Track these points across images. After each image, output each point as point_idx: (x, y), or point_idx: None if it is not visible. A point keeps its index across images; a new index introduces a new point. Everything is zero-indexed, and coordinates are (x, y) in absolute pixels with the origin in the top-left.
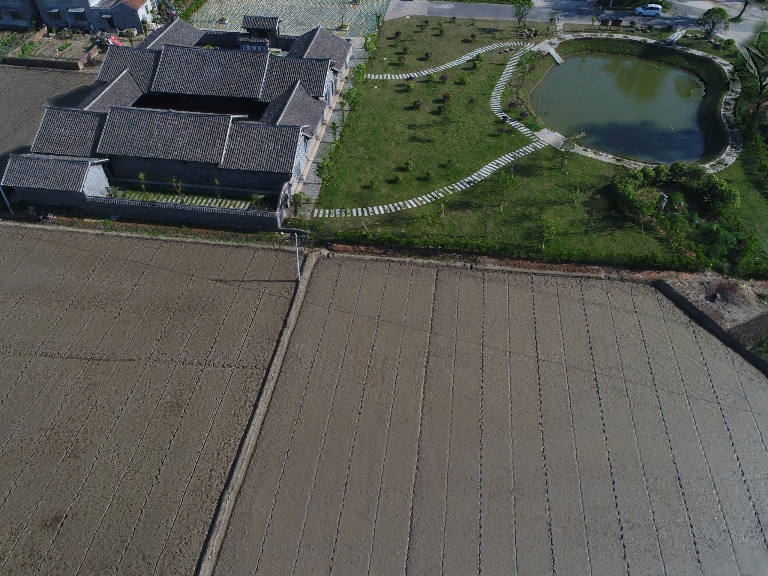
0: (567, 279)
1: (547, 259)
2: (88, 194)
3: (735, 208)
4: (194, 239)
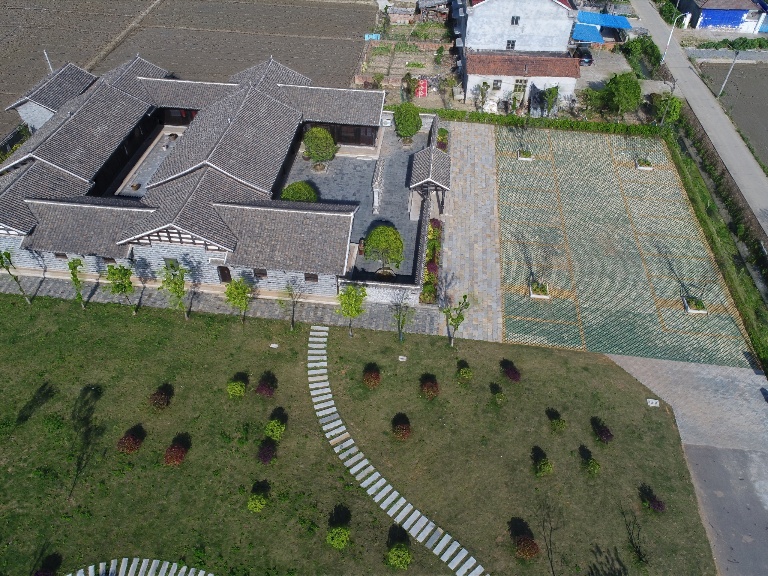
0: None
1: None
2: (27, 120)
3: None
4: None
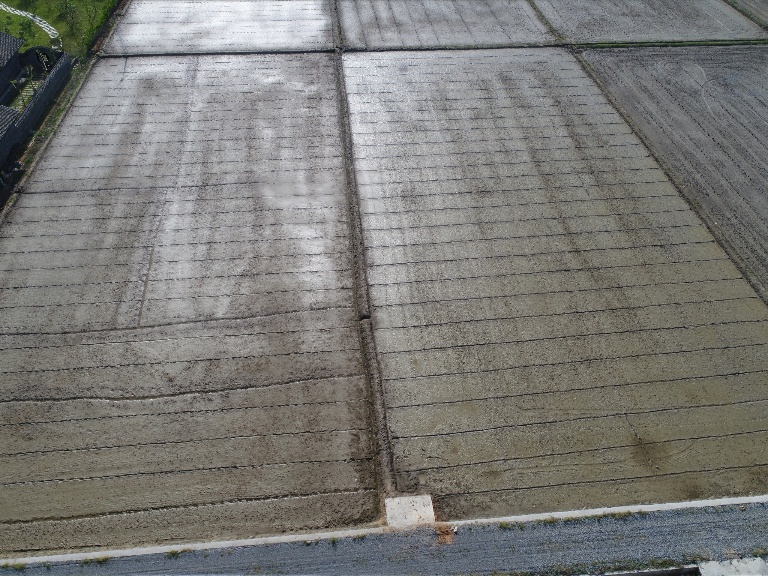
0: None
1: None
2: None
3: None
4: (73, 94)
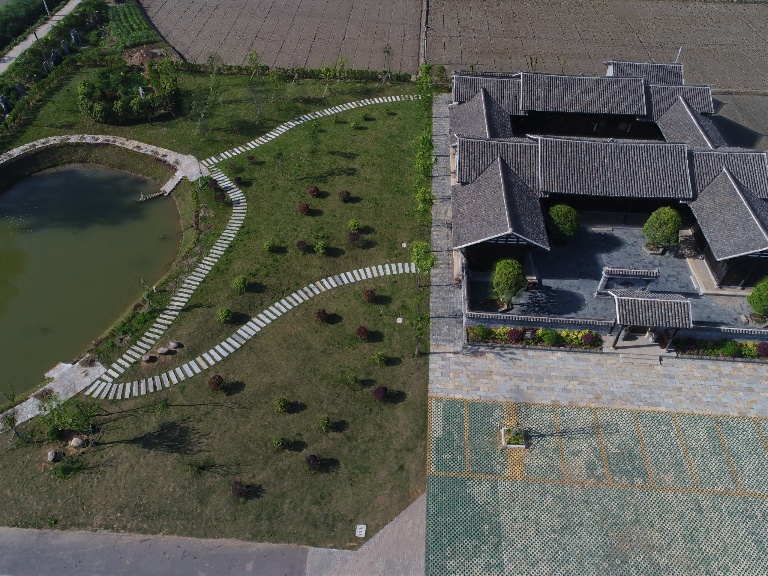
0: None
1: None
2: None
3: None
4: None
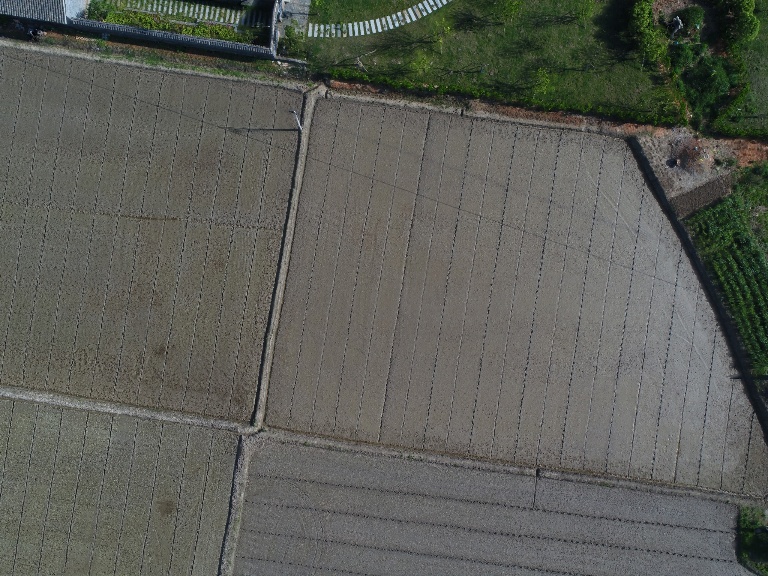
0: (549, 131)
1: (536, 105)
2: (71, 15)
3: (749, 40)
4: (193, 71)
